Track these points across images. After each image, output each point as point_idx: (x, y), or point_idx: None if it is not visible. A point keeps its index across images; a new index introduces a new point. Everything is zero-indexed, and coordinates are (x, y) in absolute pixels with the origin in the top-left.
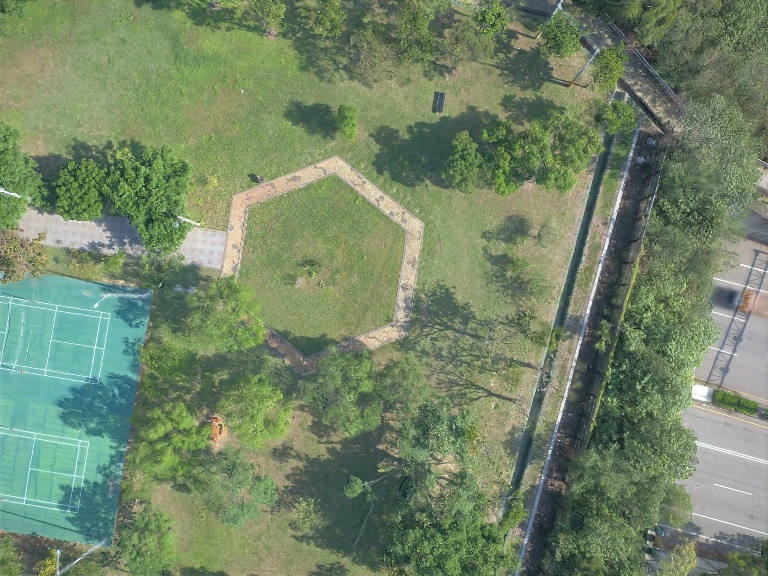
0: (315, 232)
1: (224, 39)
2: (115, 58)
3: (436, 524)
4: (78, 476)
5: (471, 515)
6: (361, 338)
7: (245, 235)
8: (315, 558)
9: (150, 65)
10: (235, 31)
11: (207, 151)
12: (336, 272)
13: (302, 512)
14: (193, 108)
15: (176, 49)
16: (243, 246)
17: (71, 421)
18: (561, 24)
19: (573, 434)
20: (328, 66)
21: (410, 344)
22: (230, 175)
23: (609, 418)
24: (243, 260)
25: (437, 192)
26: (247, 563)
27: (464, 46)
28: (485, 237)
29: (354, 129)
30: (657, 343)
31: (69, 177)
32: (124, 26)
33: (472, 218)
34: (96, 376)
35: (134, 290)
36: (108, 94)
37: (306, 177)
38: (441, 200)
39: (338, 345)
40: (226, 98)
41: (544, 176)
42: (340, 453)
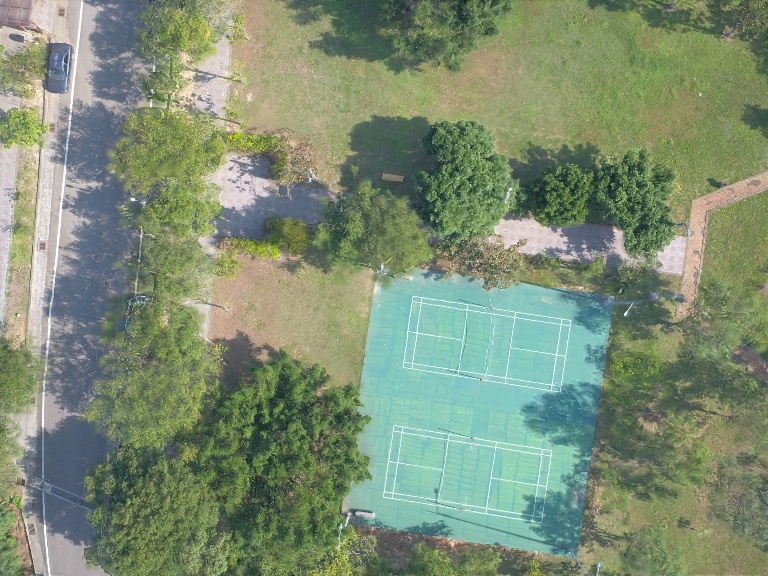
0: None
1: (680, 41)
2: (570, 60)
3: None
4: (541, 485)
5: None
6: None
7: (706, 240)
8: None
9: (605, 68)
10: (691, 33)
11: (665, 155)
12: None
13: None
14: (650, 111)
15: (632, 51)
16: (704, 252)
17: (534, 430)
18: None
19: None
20: None
21: None
22: (689, 179)
23: None
24: (704, 266)
25: None
26: (709, 573)
27: None
28: None
29: None
30: None
31: (559, 182)
32: (578, 28)
33: None
34: (558, 384)
35: (594, 296)
36: (563, 97)
37: (765, 181)
38: None
39: None
40: (683, 101)
41: None
42: None
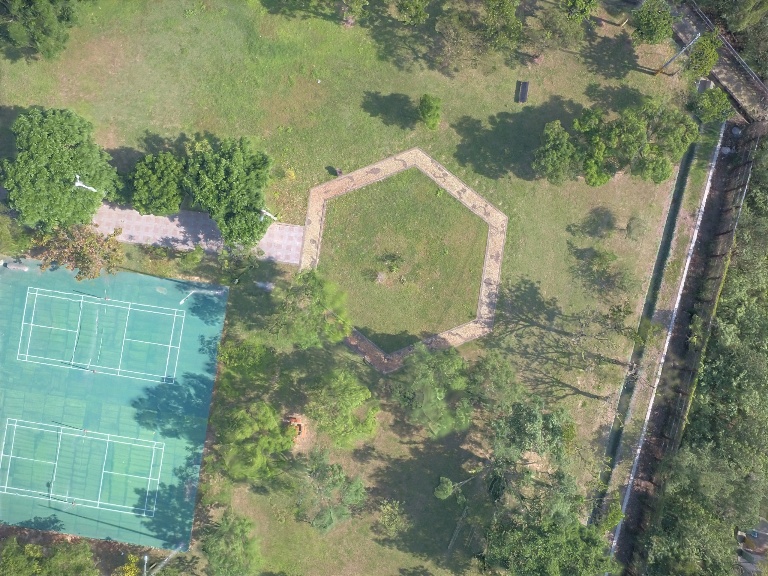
0: (395, 226)
1: (300, 28)
2: (188, 48)
3: (534, 526)
4: (153, 479)
5: (569, 517)
6: (444, 335)
7: (323, 229)
8: (398, 562)
9: (224, 55)
10: (311, 20)
11: (283, 143)
12: (417, 267)
13: (387, 515)
14: (268, 99)
15: (250, 38)
16: (321, 241)
17: (146, 422)
18: (653, 10)
19: (659, 433)
20: (407, 55)
21: (494, 341)
22: (307, 168)
23: (700, 416)
24: (321, 255)
25: (520, 184)
26: (328, 567)
27: (555, 32)
28: (570, 230)
29: (438, 119)
30: (752, 338)
31: (147, 170)
32: (197, 15)
33: (557, 211)
34: (171, 376)
35: (209, 287)
36: (181, 85)
37: (385, 169)
38: (525, 192)
39: (420, 342)
40: (302, 88)
41: (641, 166)
42: (423, 453)
